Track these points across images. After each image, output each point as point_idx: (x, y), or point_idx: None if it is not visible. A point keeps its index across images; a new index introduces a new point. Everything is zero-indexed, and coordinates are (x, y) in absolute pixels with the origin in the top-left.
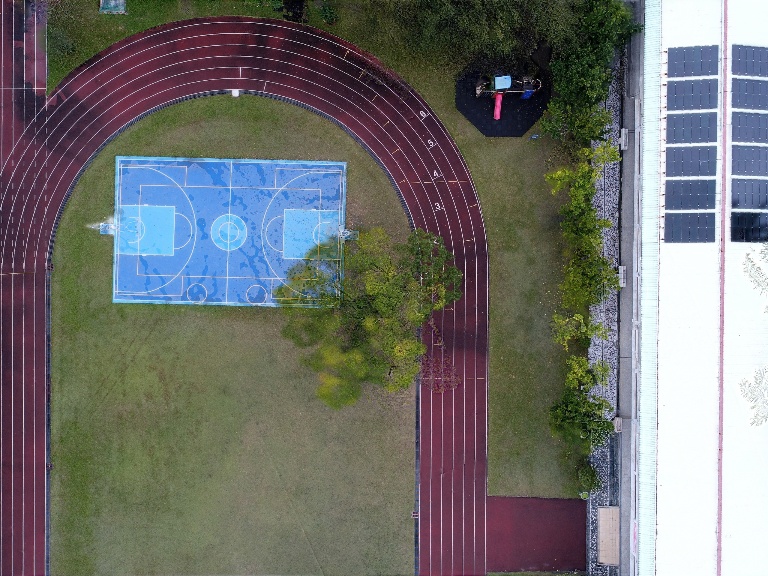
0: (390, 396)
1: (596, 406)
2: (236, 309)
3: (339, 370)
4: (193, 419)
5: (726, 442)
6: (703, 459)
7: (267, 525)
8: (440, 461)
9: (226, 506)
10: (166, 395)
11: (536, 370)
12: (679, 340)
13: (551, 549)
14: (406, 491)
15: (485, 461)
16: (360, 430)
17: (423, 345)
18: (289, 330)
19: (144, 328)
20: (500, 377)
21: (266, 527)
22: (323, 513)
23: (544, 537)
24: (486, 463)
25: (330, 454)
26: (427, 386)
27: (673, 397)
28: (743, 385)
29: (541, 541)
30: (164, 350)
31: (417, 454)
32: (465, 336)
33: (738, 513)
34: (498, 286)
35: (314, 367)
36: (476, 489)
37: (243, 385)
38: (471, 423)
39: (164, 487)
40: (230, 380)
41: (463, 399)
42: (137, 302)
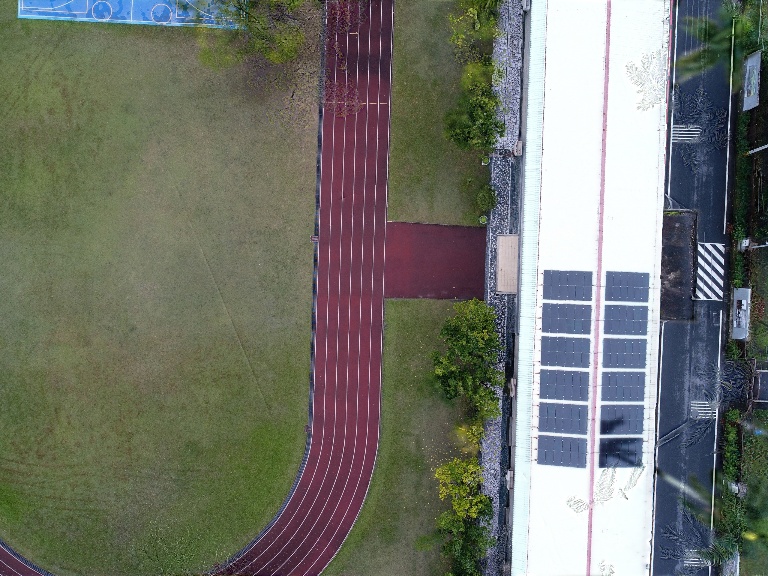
0: (292, 119)
1: (498, 133)
2: (141, 28)
3: (242, 91)
4: (95, 136)
5: (610, 123)
6: (587, 140)
7: (166, 245)
8: (341, 185)
9: (125, 225)
10: (68, 112)
11: (439, 96)
12: (567, 22)
13: (450, 276)
14: (306, 215)
15: (386, 186)
16: (261, 152)
17: (327, 69)
18: (193, 50)
19: (48, 44)
20: (403, 102)
21: (165, 247)
22: (222, 234)
23: (443, 264)
24: (387, 188)
25: (231, 175)
26: (330, 110)
27: (560, 80)
28: (630, 68)
29: (440, 268)
30: (68, 67)
31: (318, 178)
32: (369, 60)
33: (621, 196)
34: (403, 11)
35: (217, 87)
36: (376, 214)
37: (145, 104)
38: (373, 148)
39: (64, 204)
40: (133, 98)
41: (365, 124)
42: (42, 18)
